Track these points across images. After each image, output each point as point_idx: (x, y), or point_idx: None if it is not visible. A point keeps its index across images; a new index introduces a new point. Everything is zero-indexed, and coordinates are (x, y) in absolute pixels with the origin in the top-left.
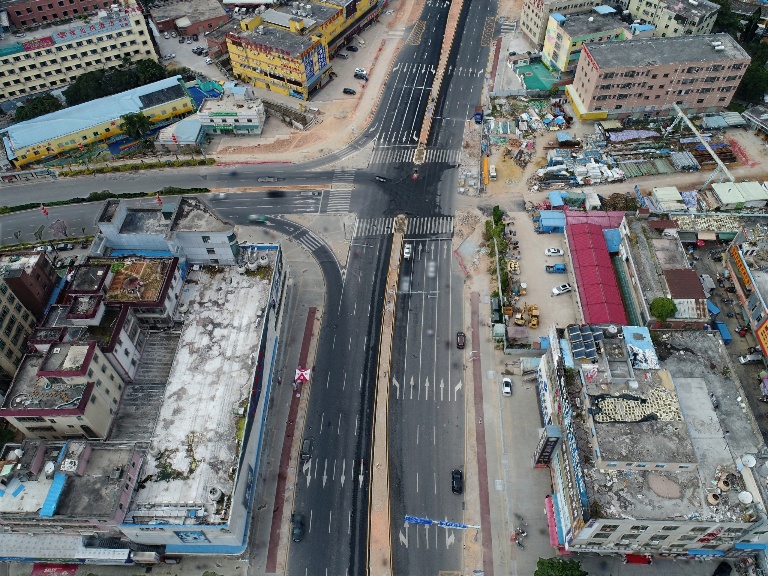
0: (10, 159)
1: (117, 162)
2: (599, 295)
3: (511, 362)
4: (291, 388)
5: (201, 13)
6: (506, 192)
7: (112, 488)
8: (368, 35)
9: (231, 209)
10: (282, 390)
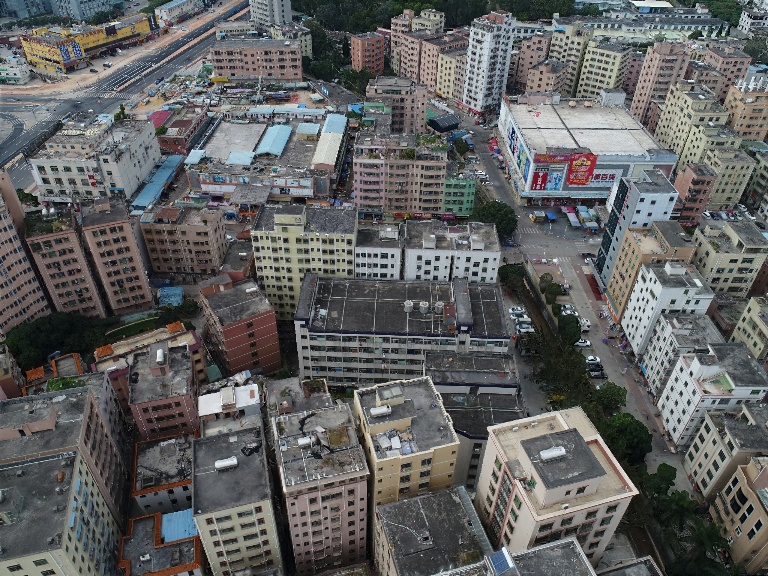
0: None
1: None
2: None
3: None
4: None
5: None
6: (147, 109)
7: None
8: (129, 50)
9: None
10: None
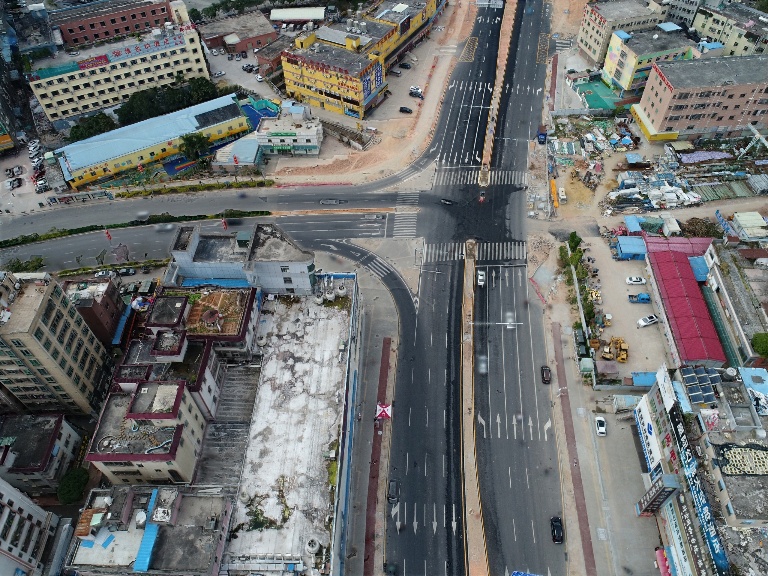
0: (67, 180)
1: (174, 183)
2: (693, 328)
3: (601, 399)
4: (372, 425)
5: (250, 30)
6: (578, 216)
7: (207, 540)
8: (420, 52)
9: (294, 233)
10: (362, 427)
